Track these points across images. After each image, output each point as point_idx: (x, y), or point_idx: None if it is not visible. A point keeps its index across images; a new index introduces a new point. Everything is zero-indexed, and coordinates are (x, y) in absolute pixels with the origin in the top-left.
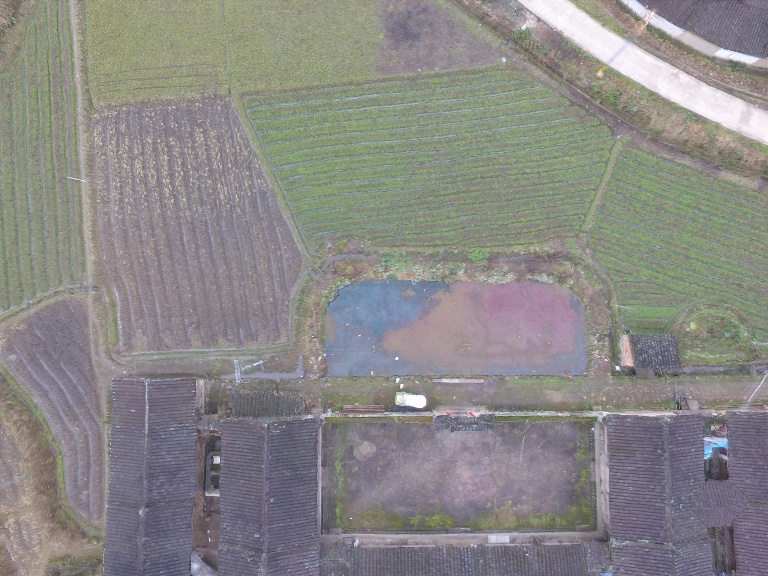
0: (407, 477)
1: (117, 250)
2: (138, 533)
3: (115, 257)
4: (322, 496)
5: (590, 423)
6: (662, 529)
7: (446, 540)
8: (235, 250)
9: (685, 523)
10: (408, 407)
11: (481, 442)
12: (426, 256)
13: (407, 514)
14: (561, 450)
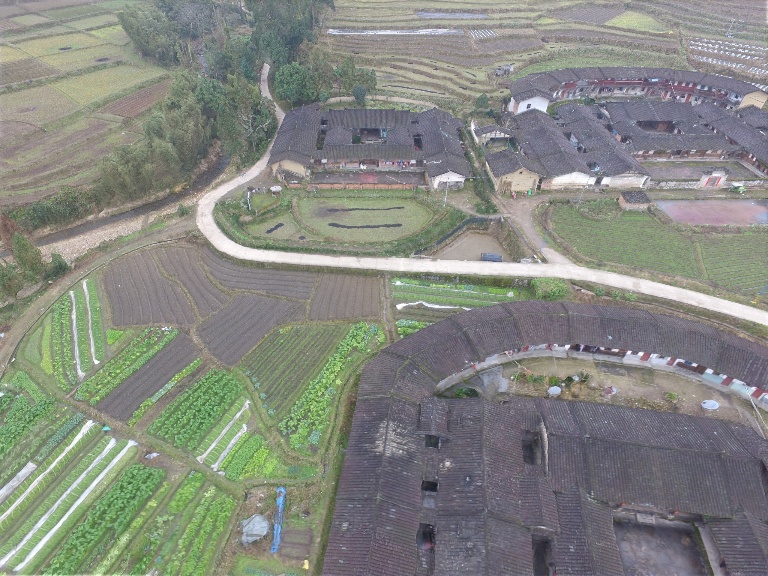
0: None
1: None
2: None
3: None
4: None
5: None
6: None
7: None
8: None
9: None
10: None
11: None
12: None
13: (705, 165)
14: None
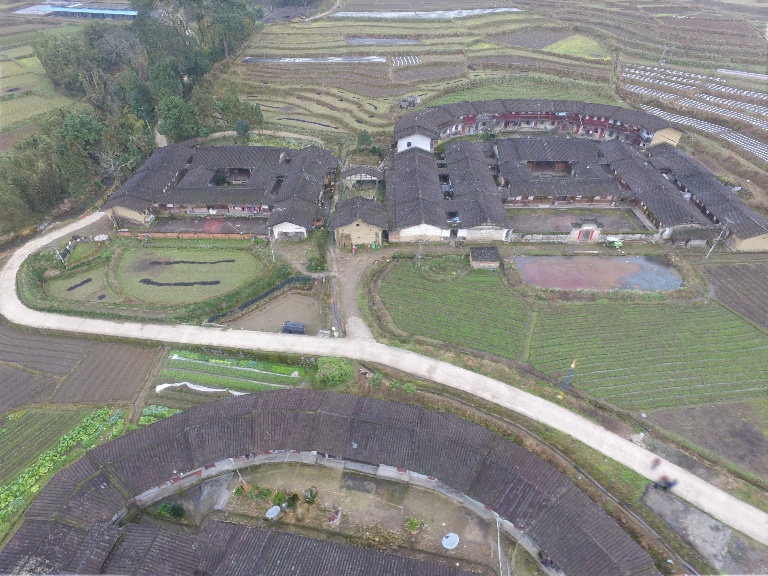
0: None
1: None
2: None
3: None
4: None
5: None
6: (482, 195)
7: (569, 206)
8: (766, 302)
9: None
10: None
11: None
12: None
13: (592, 213)
14: (521, 230)
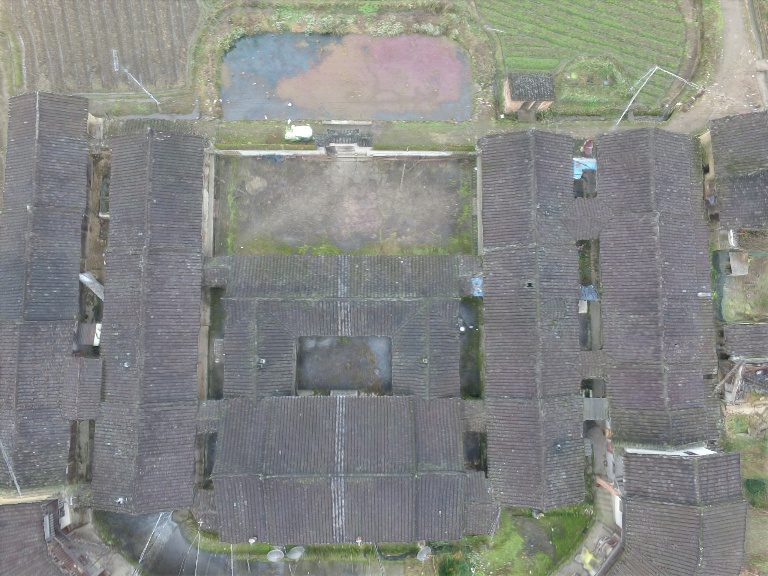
0: (296, 210)
1: (23, 1)
2: (26, 229)
3: (21, 7)
4: (214, 226)
5: (473, 163)
6: (528, 232)
7: None
8: (135, 1)
9: (552, 230)
10: (297, 143)
11: (368, 178)
12: (319, 9)
13: (296, 244)
14: (445, 187)
